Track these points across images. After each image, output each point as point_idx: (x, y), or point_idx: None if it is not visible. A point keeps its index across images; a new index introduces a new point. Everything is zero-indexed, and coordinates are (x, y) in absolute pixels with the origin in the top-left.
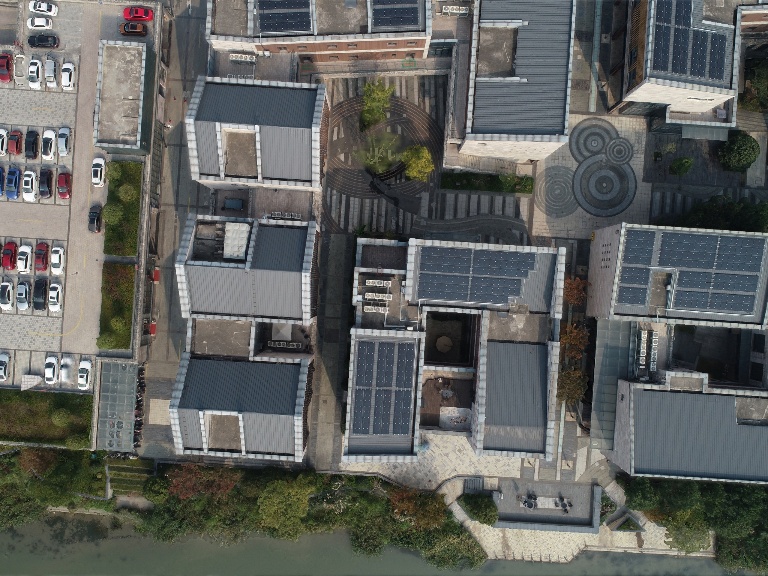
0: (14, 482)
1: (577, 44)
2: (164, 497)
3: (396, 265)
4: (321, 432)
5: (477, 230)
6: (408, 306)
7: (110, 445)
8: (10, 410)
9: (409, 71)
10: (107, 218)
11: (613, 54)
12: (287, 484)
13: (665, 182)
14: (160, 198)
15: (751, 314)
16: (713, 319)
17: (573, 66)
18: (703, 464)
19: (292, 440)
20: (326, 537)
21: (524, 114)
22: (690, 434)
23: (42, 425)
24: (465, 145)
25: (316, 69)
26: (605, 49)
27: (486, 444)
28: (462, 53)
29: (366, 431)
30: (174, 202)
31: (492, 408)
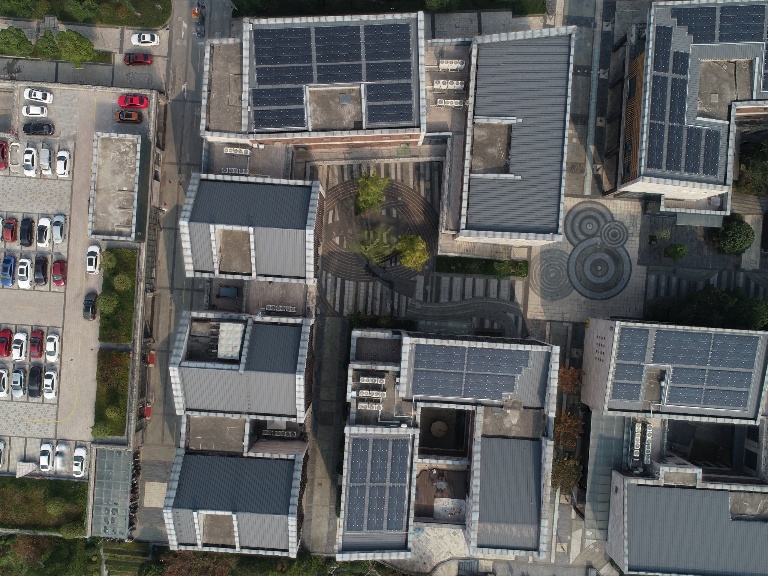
0: (9, 563)
1: (572, 127)
2: None
3: (390, 356)
4: (316, 515)
5: (472, 313)
6: (402, 401)
7: (105, 528)
8: (5, 497)
9: (404, 158)
10: (102, 308)
11: (608, 137)
12: (281, 575)
13: (660, 265)
14: (155, 281)
15: (745, 409)
16: (707, 414)
17: (568, 149)
18: (697, 561)
19: (286, 537)
20: None
21: (518, 211)
22: (684, 530)
23: (37, 514)
24: (459, 237)
25: (311, 156)
26: (600, 132)
27: (480, 542)
28: (457, 144)
29: (360, 528)
30: (169, 285)
31: (486, 505)
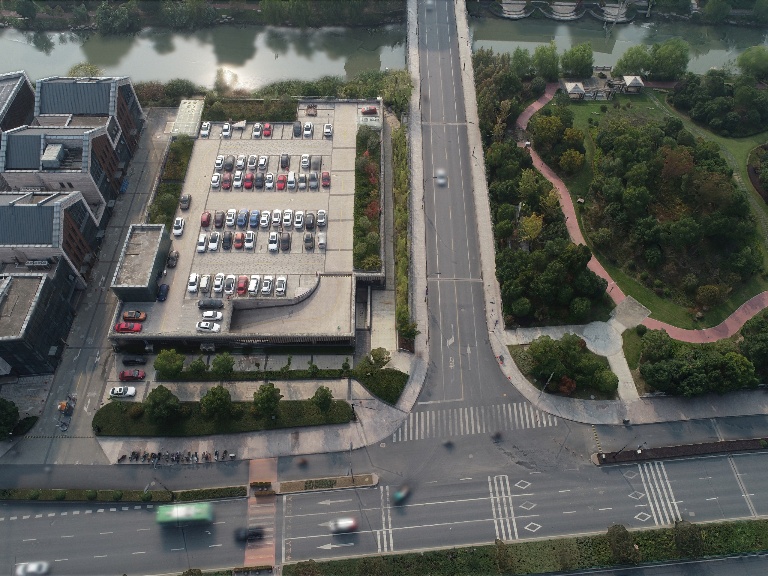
0: None
1: None
2: None
3: None
4: None
5: None
6: None
7: None
8: (255, 113)
9: None
10: None
11: None
12: None
13: None
14: None
15: None
16: None
17: None
18: None
19: None
20: None
21: None
22: None
23: None
24: None
25: None
26: None
27: None
28: None
29: (8, 86)
30: None
31: None
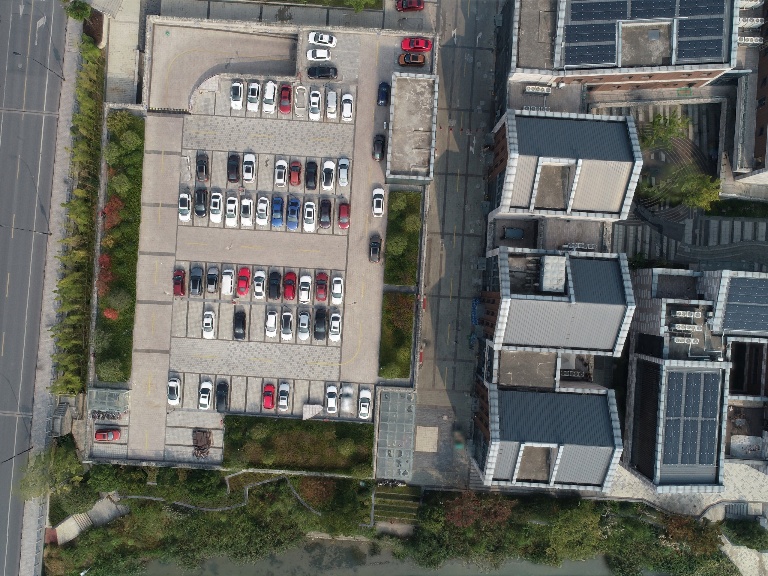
0: (278, 509)
1: None
2: (442, 525)
3: (686, 294)
4: None
5: (741, 256)
6: (712, 336)
7: None
8: (291, 439)
9: (685, 100)
10: (394, 249)
11: None
12: (580, 513)
13: None
14: None
15: None
16: None
17: None
18: None
19: (603, 471)
20: (582, 562)
21: None
22: None
23: None
24: (757, 175)
25: (592, 98)
26: None
27: None
28: (751, 83)
29: (675, 461)
30: (440, 230)
31: None
